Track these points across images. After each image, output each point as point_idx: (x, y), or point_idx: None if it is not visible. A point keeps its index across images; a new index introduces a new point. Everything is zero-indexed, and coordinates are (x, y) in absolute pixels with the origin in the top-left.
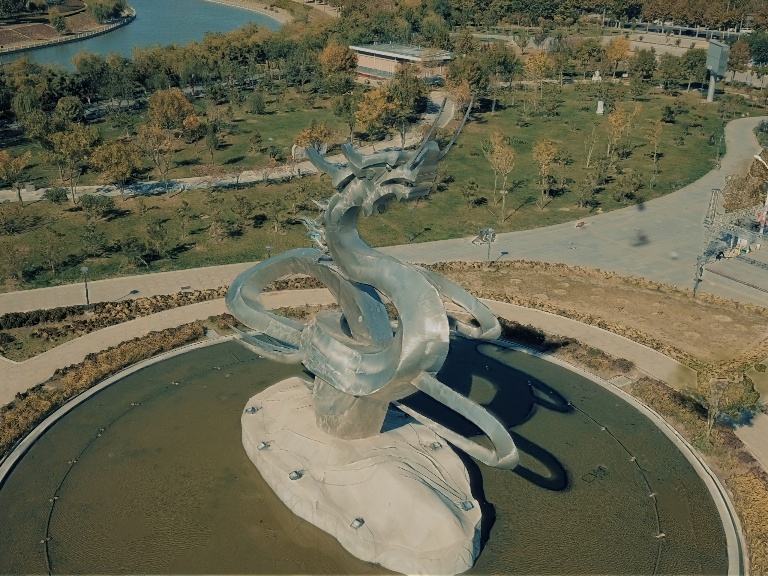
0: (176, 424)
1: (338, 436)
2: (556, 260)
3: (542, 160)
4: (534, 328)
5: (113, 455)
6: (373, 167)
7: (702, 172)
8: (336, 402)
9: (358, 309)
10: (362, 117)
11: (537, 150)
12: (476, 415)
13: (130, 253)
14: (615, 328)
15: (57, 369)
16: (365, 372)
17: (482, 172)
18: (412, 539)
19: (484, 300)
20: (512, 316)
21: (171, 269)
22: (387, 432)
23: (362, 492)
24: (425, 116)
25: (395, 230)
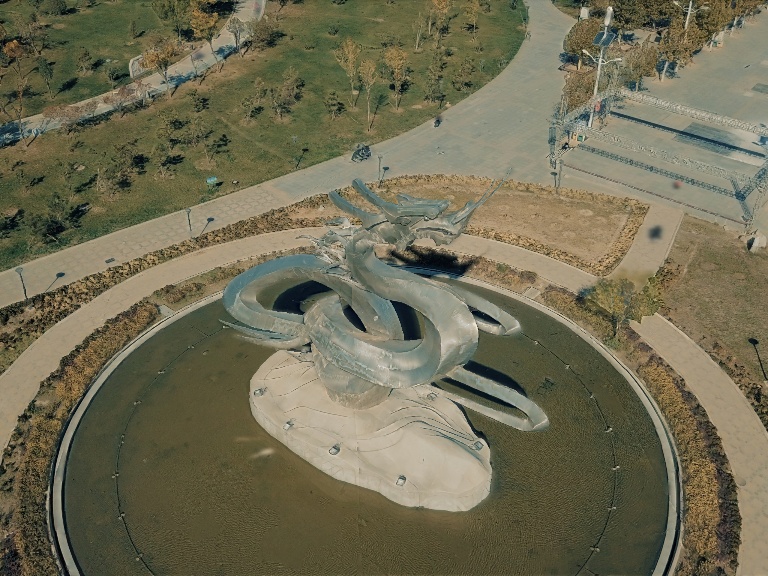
0: (186, 415)
1: (356, 408)
2: (433, 170)
3: (395, 65)
4: (446, 251)
5: (148, 460)
6: (409, 216)
7: (517, 44)
8: (352, 382)
9: (373, 311)
10: (199, 26)
11: (389, 56)
12: (513, 399)
13: (38, 233)
14: (509, 239)
15: (41, 382)
16: (400, 369)
17: (325, 70)
18: (450, 485)
19: None
20: (422, 241)
21: (82, 240)
22: (391, 394)
23: (396, 454)
24: None
25: (276, 156)
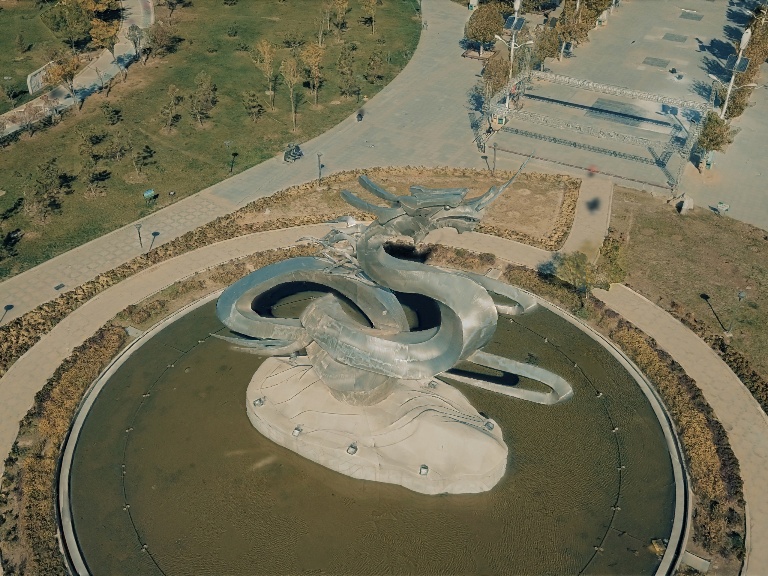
0: (184, 435)
1: (365, 405)
2: (368, 164)
3: (312, 62)
4: (402, 242)
5: (156, 487)
6: (428, 207)
7: (416, 35)
8: (359, 379)
9: (382, 306)
10: (99, 35)
11: (306, 53)
12: (538, 374)
13: None
14: None
15: (19, 422)
16: (419, 359)
17: (234, 72)
18: (472, 467)
19: None
20: None
21: (23, 269)
22: (395, 387)
23: (413, 445)
24: (122, 5)
25: (207, 163)
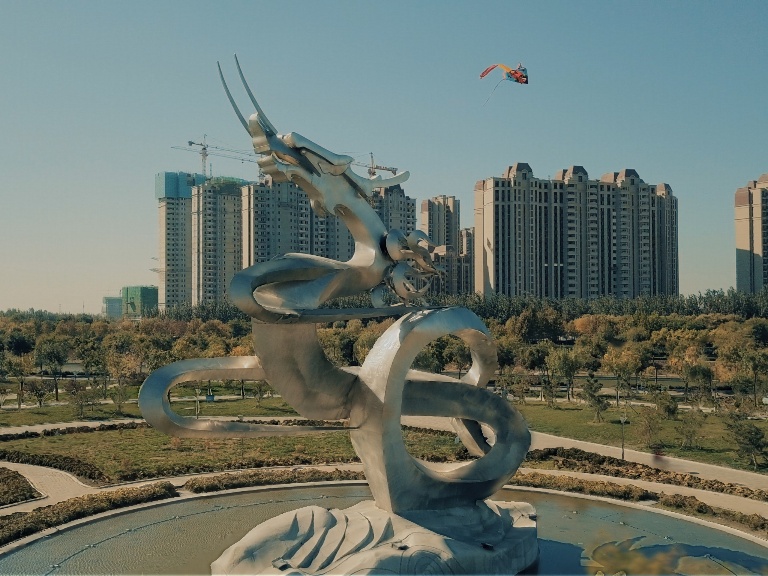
0: None
1: None
2: None
3: None
4: None
5: None
6: None
7: None
8: None
9: None
10: None
11: None
12: None
13: (741, 445)
14: None
15: None
16: None
17: None
18: None
19: None
20: None
21: None
22: (404, 518)
23: None
24: None
25: None
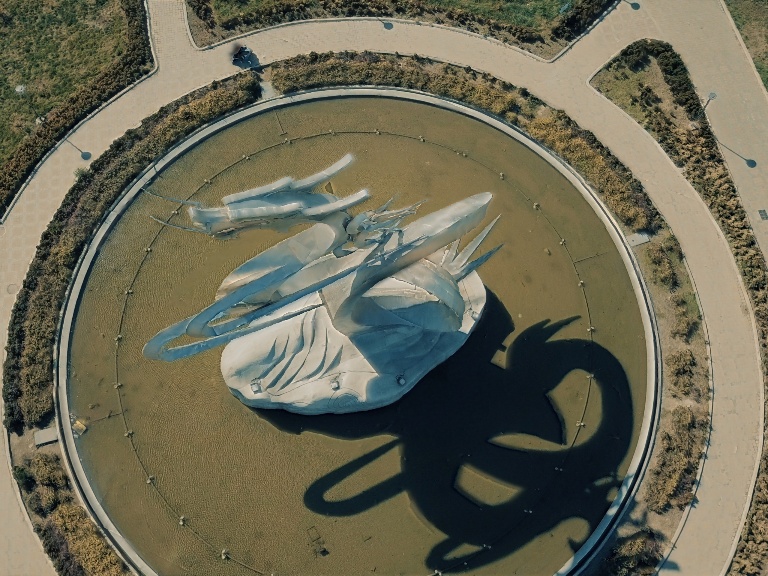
0: None
1: None
2: None
3: None
4: None
5: (428, 164)
6: None
7: None
8: None
9: None
10: None
11: None
12: None
13: None
14: None
15: (564, 110)
16: None
17: None
18: (236, 342)
19: (719, 574)
20: None
21: None
22: (354, 345)
23: None
24: None
25: None
